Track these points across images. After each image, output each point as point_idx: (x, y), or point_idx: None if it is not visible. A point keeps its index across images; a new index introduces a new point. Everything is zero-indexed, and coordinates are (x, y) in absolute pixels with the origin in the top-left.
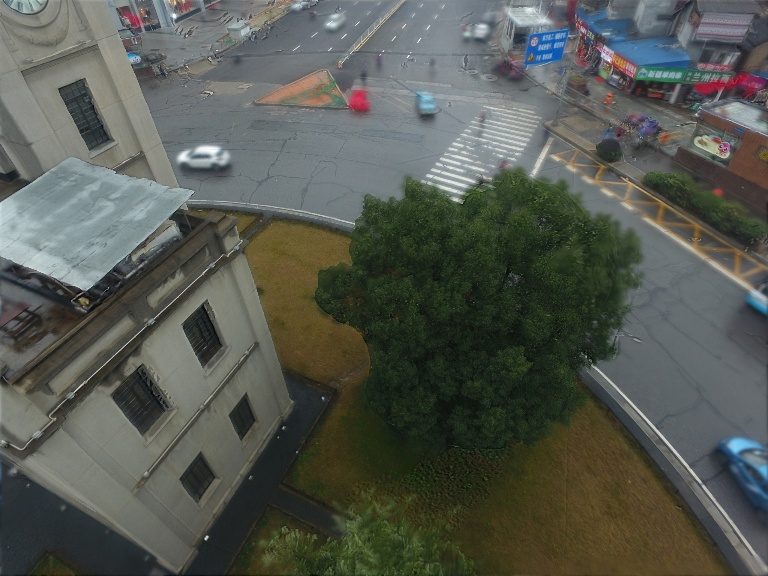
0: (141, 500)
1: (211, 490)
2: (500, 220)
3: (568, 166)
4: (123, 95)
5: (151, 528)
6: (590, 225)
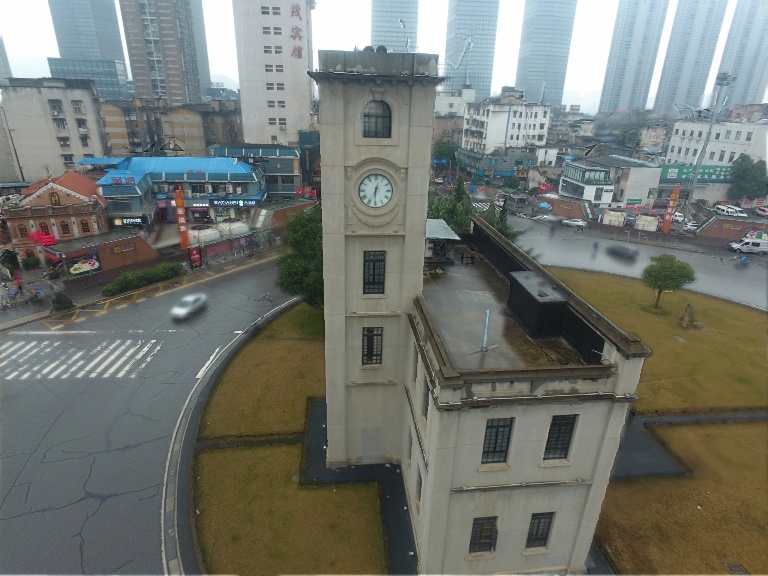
0: None
1: None
2: None
3: (77, 321)
4: None
5: None
6: None
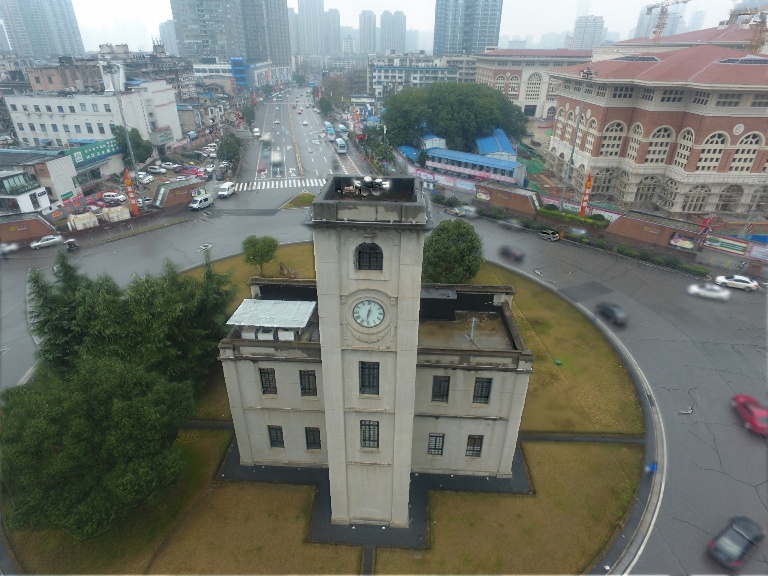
0: None
1: None
2: None
3: None
4: None
5: None
6: None
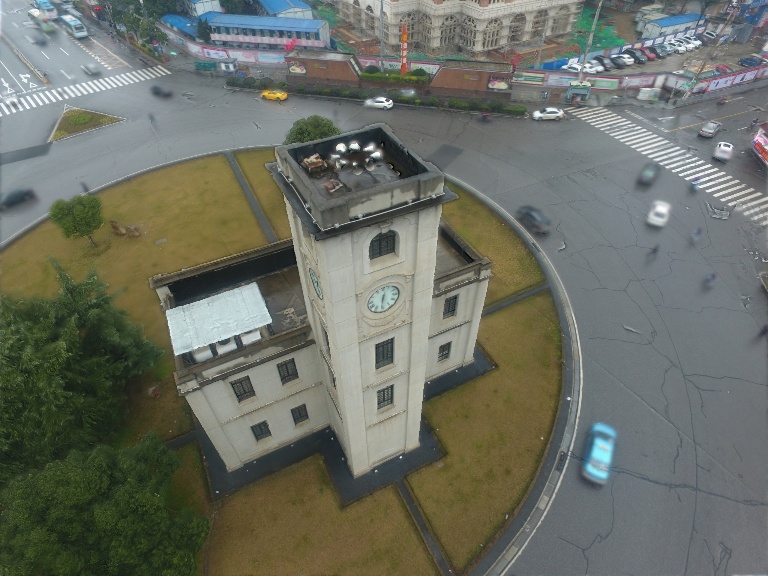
0: None
1: None
2: (7, 511)
3: None
4: None
5: None
6: None
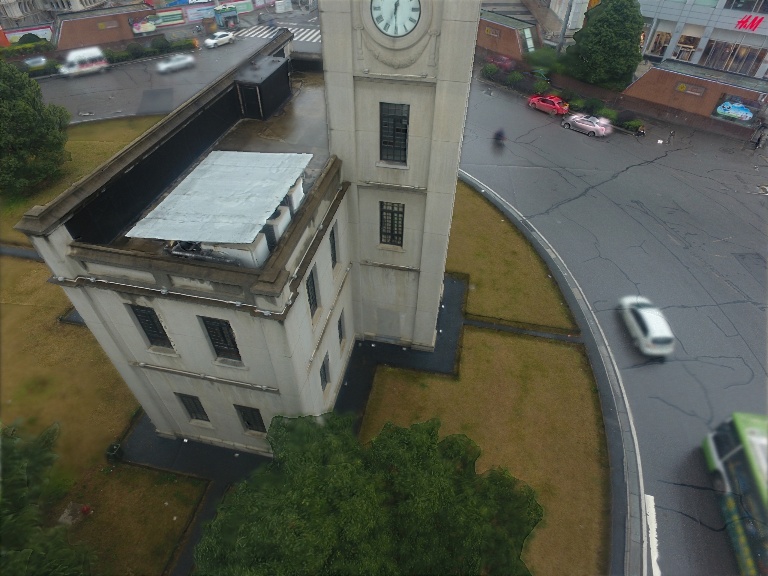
0: (137, 372)
1: (204, 424)
2: None
3: None
4: (436, 136)
5: (140, 391)
6: None
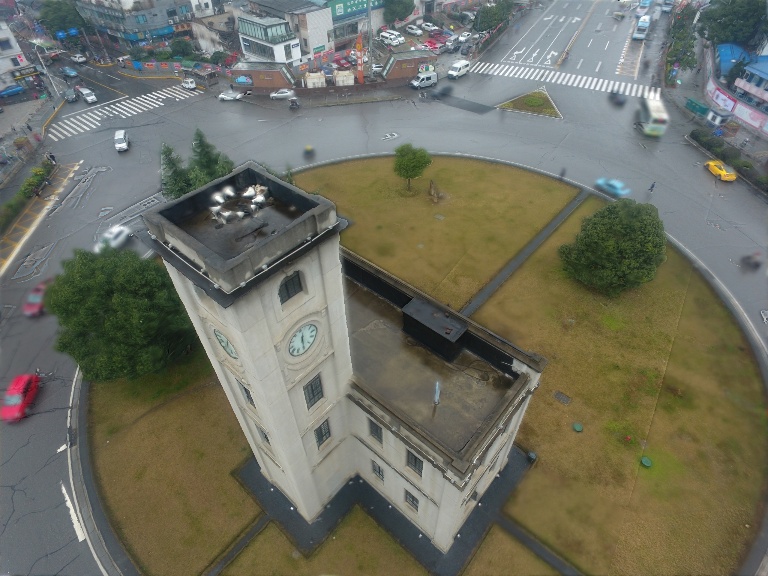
0: None
1: None
2: None
3: None
4: None
5: None
6: (83, 254)
